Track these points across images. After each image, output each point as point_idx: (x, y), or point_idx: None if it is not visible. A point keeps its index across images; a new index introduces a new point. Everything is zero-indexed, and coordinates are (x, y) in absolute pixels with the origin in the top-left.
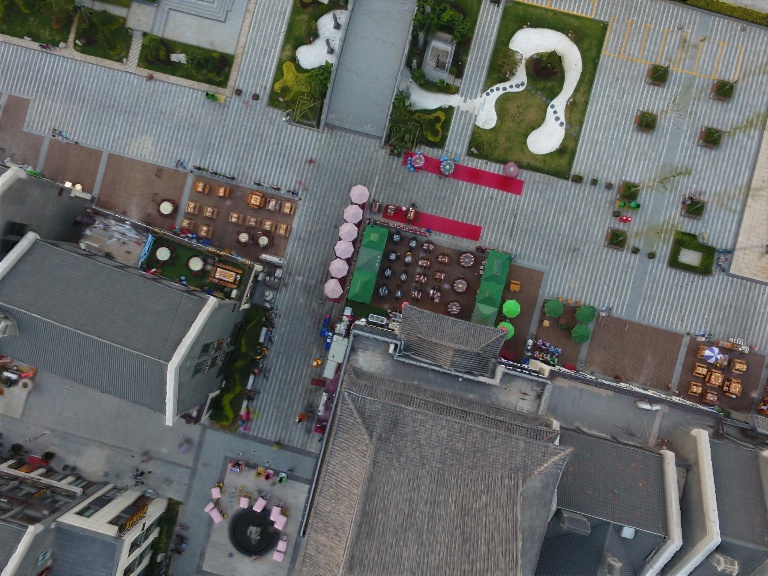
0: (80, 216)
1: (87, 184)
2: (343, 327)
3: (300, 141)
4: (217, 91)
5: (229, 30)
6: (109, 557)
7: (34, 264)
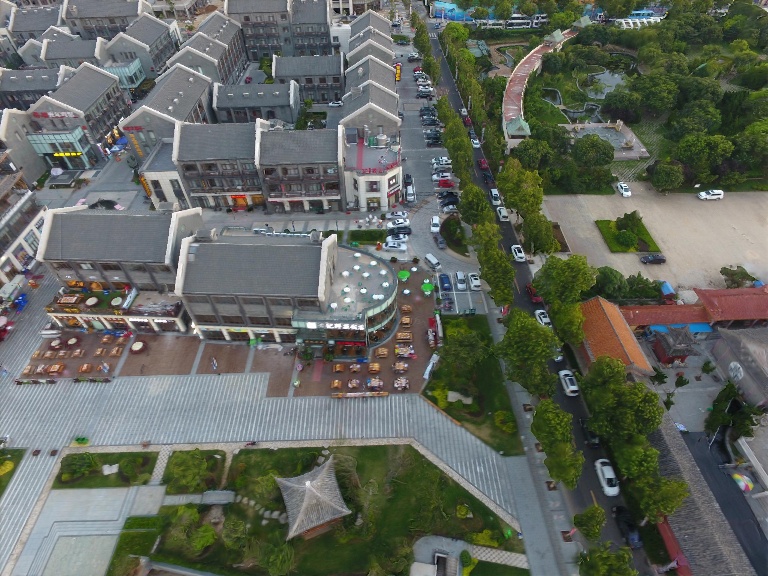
0: (177, 305)
1: (210, 349)
2: (3, 305)
3: (2, 426)
4: (77, 449)
5: (51, 515)
6: (153, 168)
7: (159, 246)
